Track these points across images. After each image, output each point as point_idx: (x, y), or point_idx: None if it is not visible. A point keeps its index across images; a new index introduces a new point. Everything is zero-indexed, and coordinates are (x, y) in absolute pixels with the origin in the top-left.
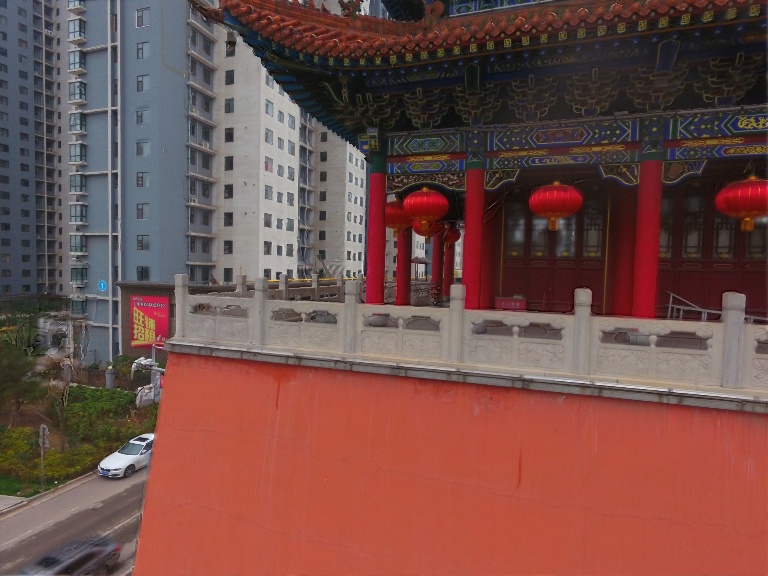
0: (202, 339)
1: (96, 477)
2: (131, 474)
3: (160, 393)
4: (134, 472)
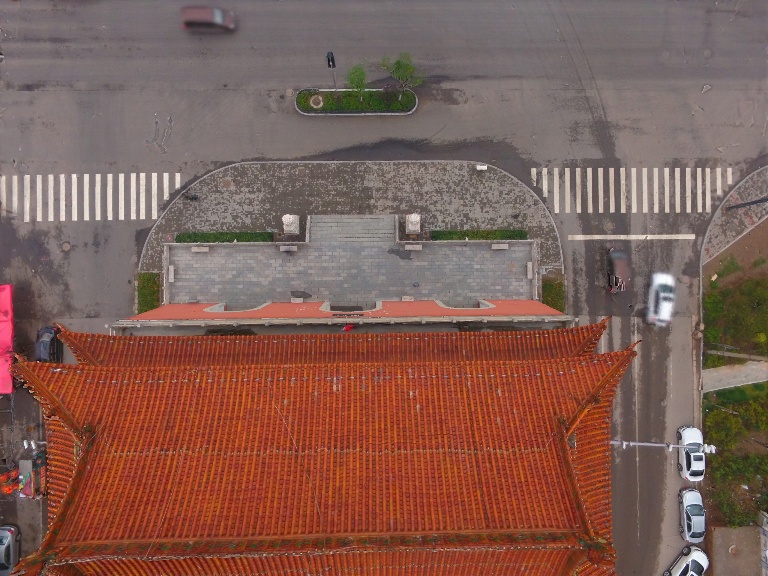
0: (559, 317)
1: (694, 425)
2: (678, 436)
3: (765, 536)
4: (678, 439)
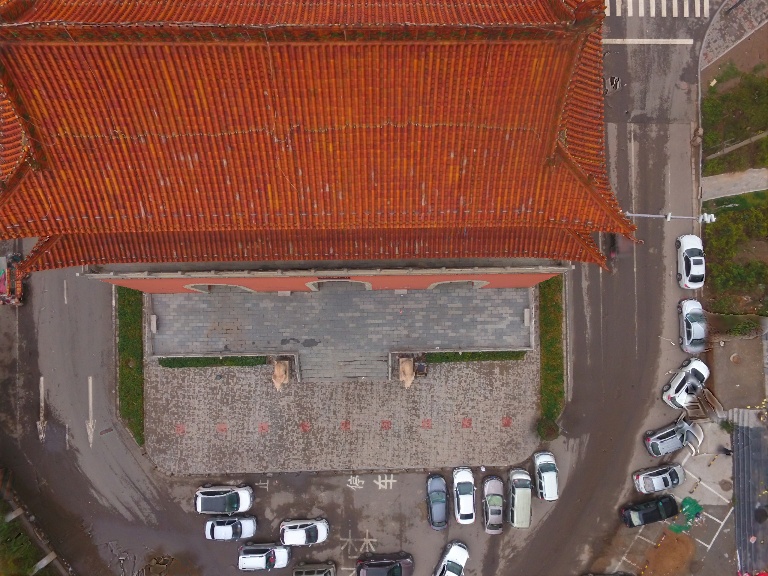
0: None
1: None
2: (676, 246)
3: (767, 341)
4: (677, 248)
